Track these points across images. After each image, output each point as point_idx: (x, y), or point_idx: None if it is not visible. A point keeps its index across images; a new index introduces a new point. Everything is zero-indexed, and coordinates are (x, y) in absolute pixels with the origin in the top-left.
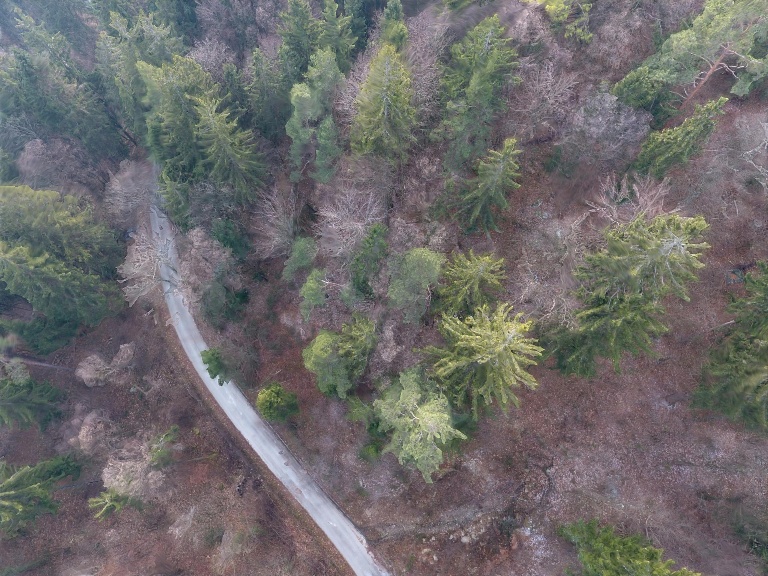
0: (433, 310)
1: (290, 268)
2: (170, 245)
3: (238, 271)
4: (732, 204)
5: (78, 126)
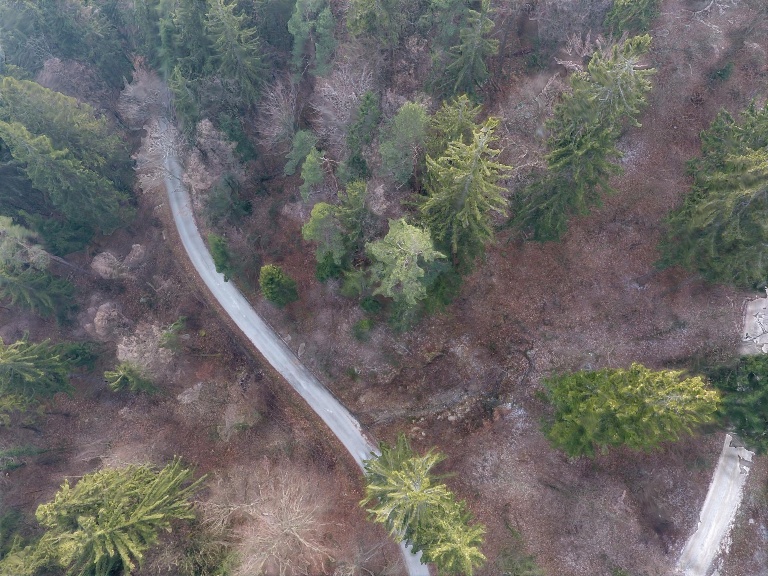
0: (420, 176)
1: (291, 163)
2: (178, 171)
3: (243, 167)
4: (700, 105)
5: (93, 50)
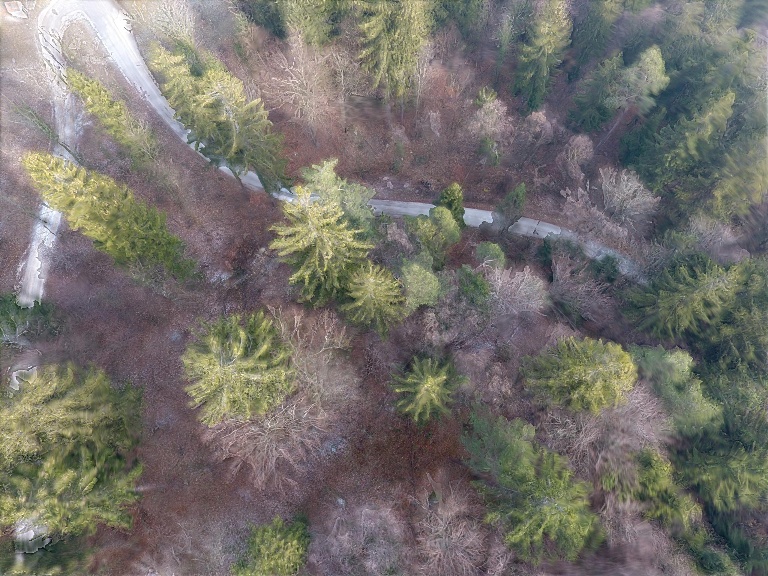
0: None
1: None
2: None
3: (565, 253)
4: None
5: None
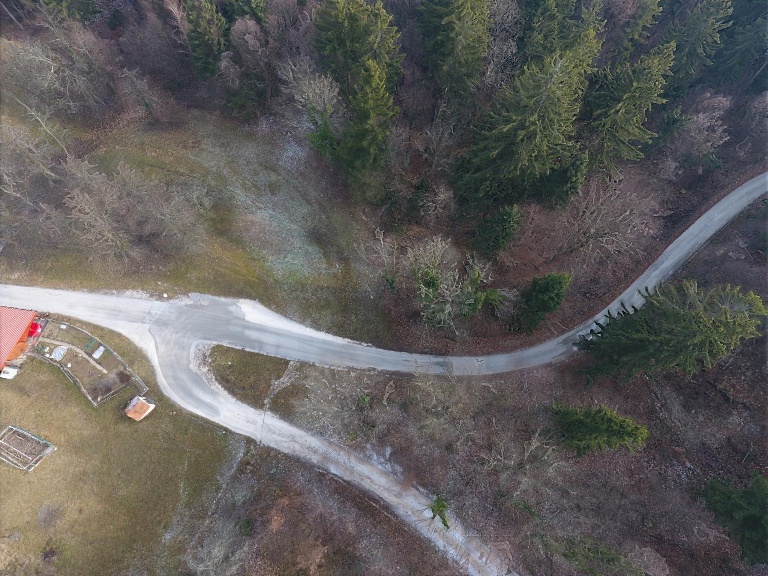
0: None
1: None
2: None
3: None
4: None
5: None
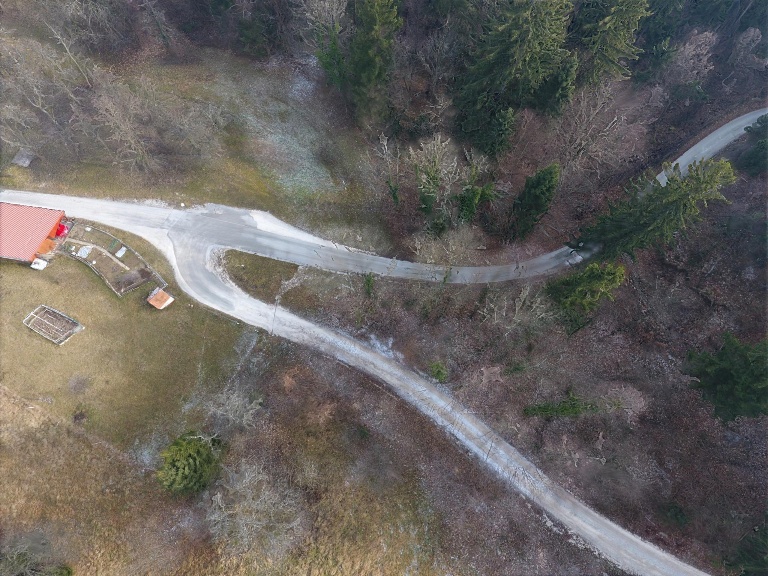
0: None
1: None
2: None
3: None
4: None
5: None
